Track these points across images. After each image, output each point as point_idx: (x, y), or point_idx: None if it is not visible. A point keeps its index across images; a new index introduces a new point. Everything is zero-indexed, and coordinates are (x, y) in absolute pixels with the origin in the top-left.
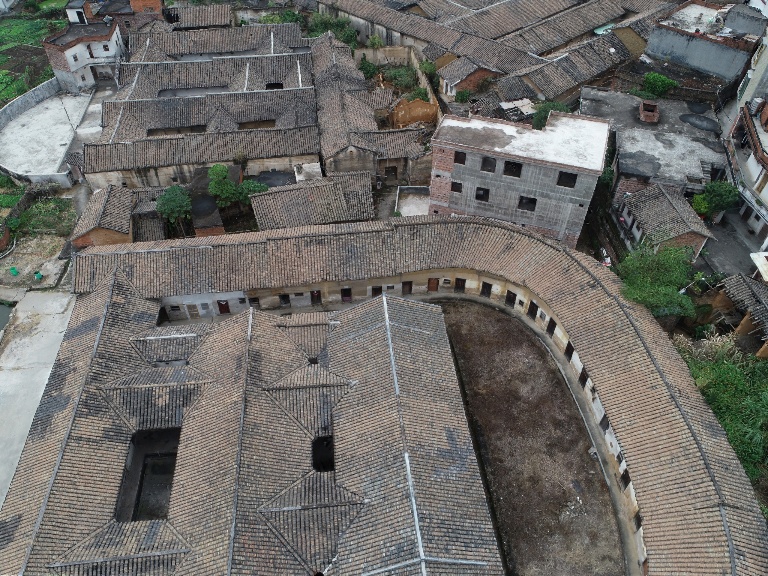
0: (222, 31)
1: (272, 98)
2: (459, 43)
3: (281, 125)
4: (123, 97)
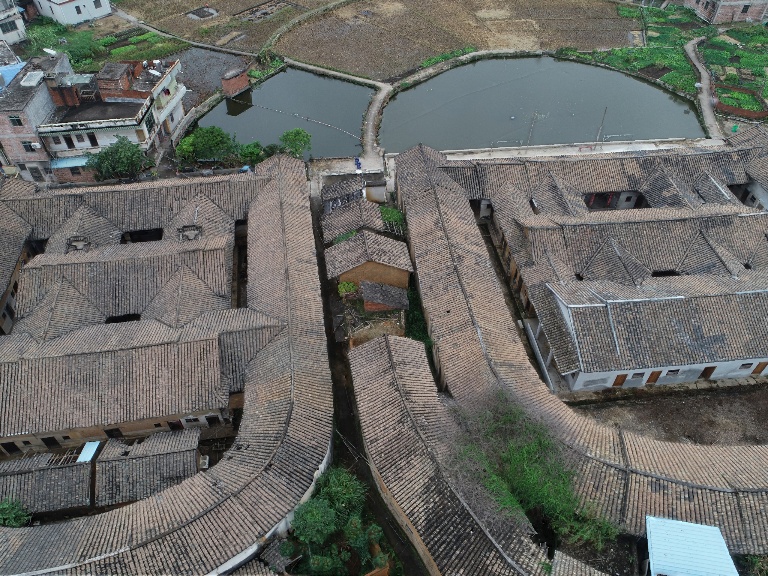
0: None
1: None
2: None
3: None
4: None
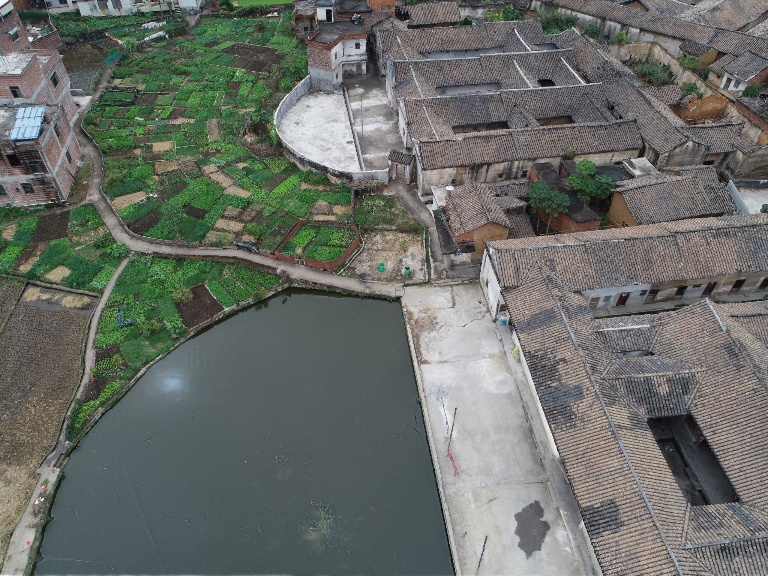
0: (466, 28)
1: (564, 94)
2: (716, 39)
3: (585, 121)
4: (412, 94)
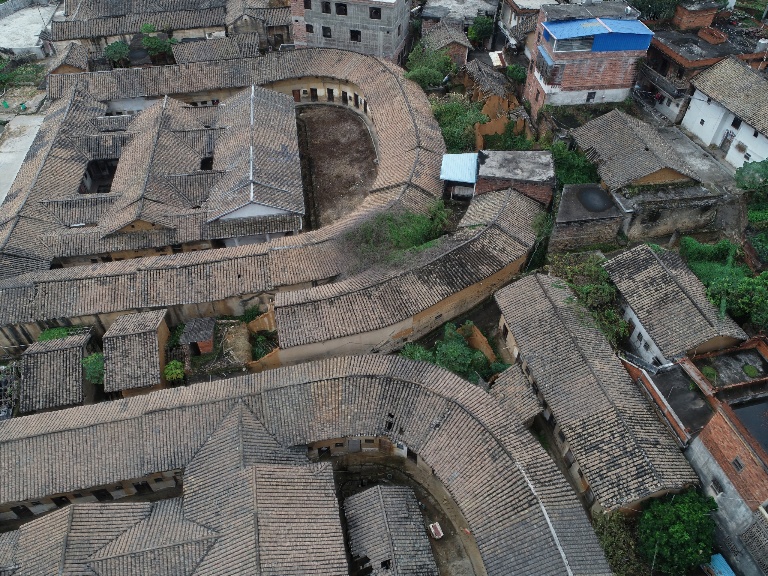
0: None
1: None
2: None
3: None
4: None
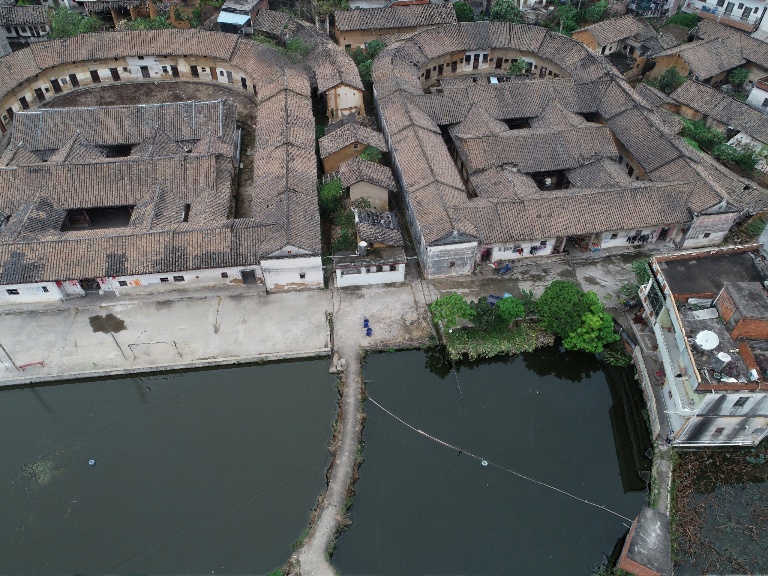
0: None
1: None
2: None
3: None
4: None
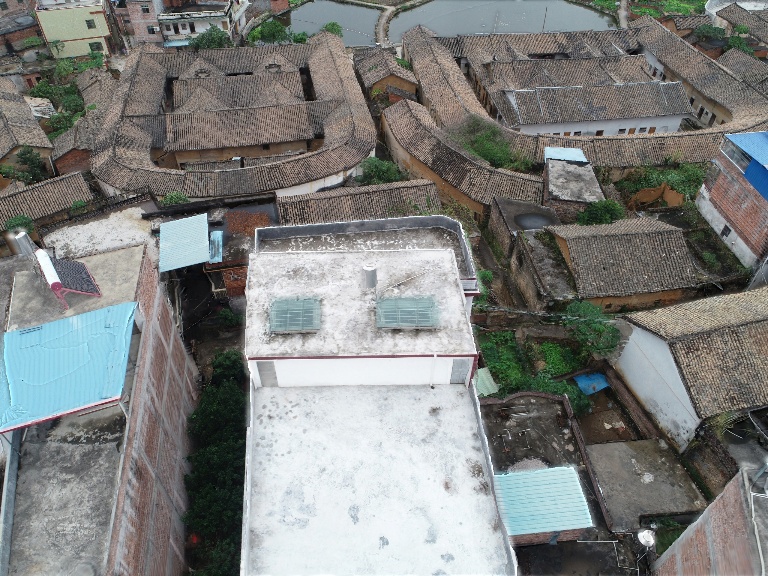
0: None
1: None
2: None
3: None
4: None
